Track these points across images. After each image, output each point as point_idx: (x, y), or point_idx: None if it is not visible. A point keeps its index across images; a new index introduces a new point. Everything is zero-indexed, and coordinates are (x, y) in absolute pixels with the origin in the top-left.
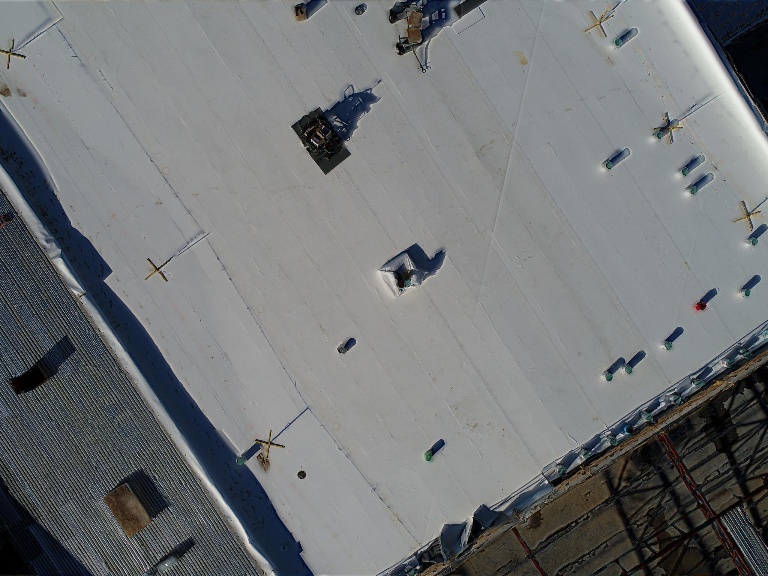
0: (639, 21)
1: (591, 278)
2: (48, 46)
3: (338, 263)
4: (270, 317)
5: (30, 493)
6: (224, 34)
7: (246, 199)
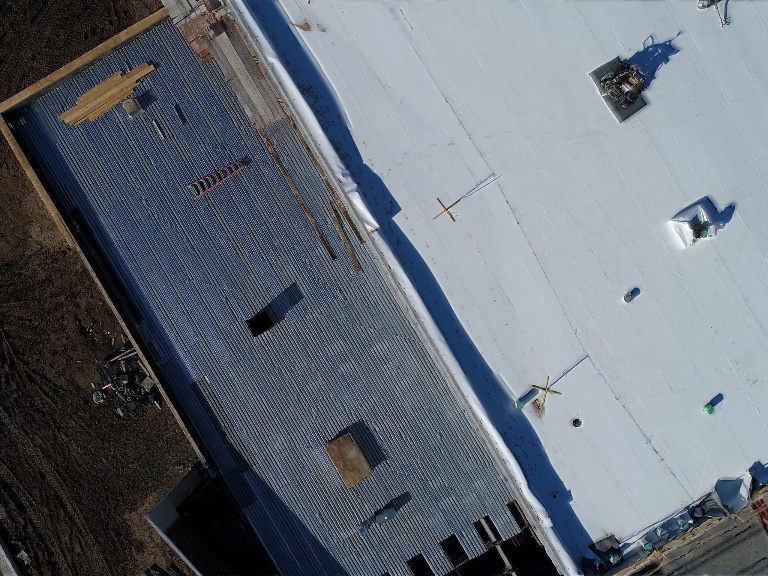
0: None
1: None
2: None
3: (627, 212)
4: (555, 263)
5: (247, 439)
6: None
7: (539, 144)
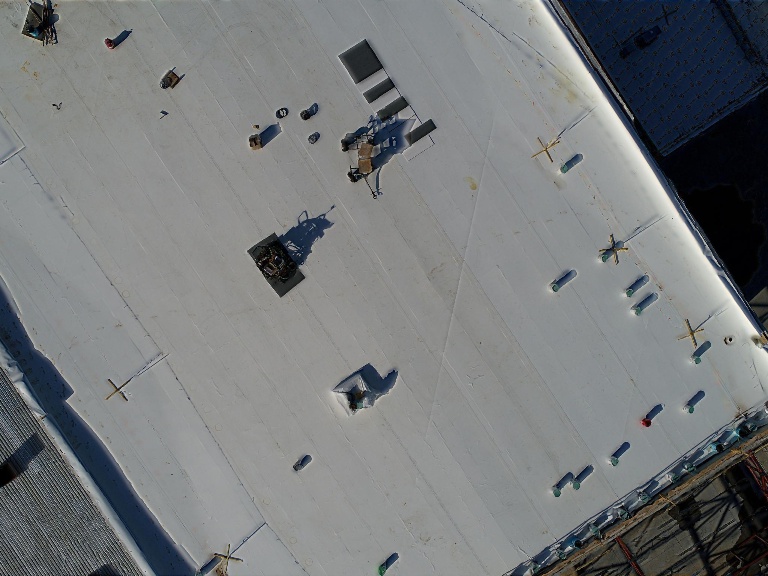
0: (584, 147)
1: (540, 396)
2: (11, 174)
3: (294, 383)
4: (228, 435)
5: None
6: (181, 162)
7: (204, 321)
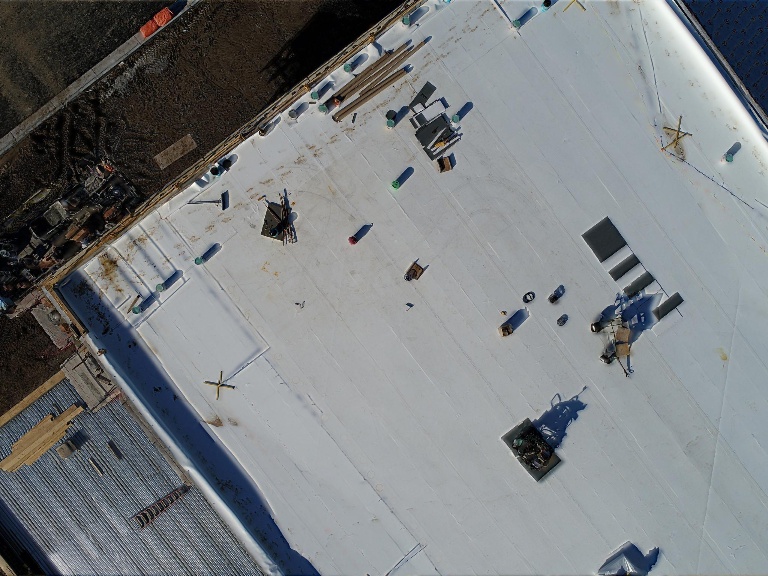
0: None
1: None
2: (256, 375)
3: (554, 565)
4: None
5: None
6: (429, 353)
7: (460, 510)
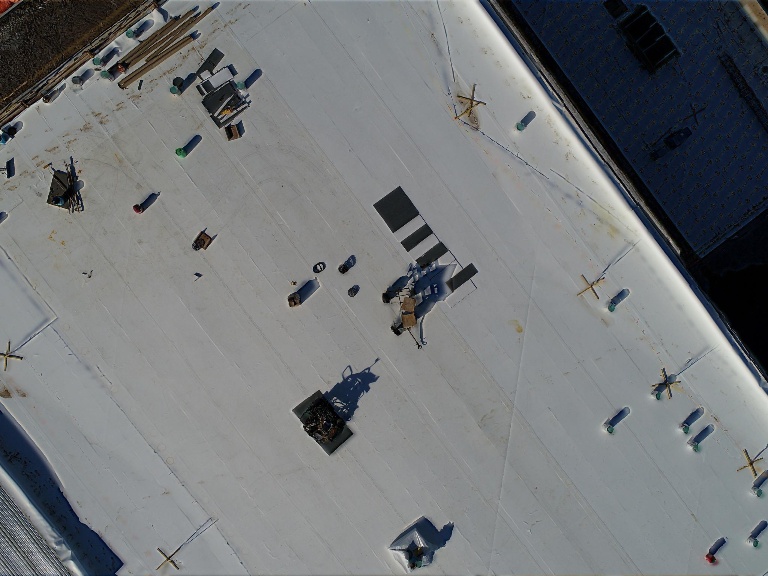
0: (630, 282)
1: (600, 537)
2: (44, 346)
3: (348, 540)
4: None
5: None
6: (219, 324)
7: (252, 484)
